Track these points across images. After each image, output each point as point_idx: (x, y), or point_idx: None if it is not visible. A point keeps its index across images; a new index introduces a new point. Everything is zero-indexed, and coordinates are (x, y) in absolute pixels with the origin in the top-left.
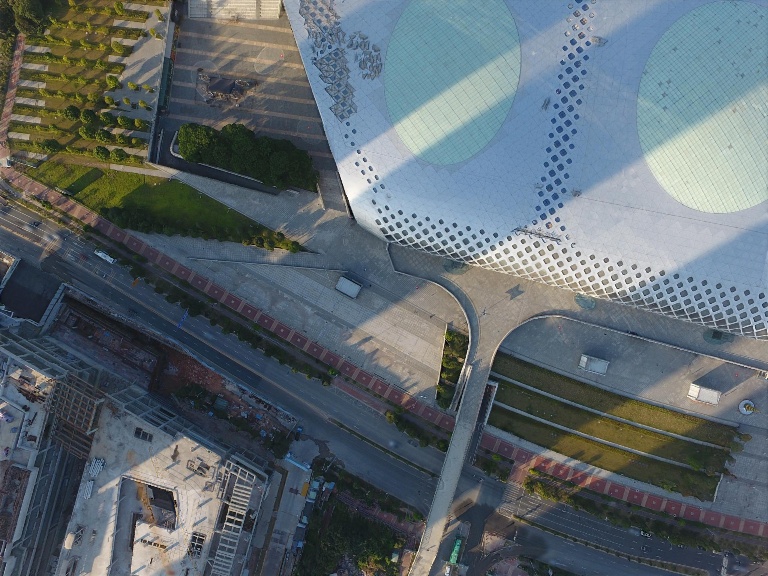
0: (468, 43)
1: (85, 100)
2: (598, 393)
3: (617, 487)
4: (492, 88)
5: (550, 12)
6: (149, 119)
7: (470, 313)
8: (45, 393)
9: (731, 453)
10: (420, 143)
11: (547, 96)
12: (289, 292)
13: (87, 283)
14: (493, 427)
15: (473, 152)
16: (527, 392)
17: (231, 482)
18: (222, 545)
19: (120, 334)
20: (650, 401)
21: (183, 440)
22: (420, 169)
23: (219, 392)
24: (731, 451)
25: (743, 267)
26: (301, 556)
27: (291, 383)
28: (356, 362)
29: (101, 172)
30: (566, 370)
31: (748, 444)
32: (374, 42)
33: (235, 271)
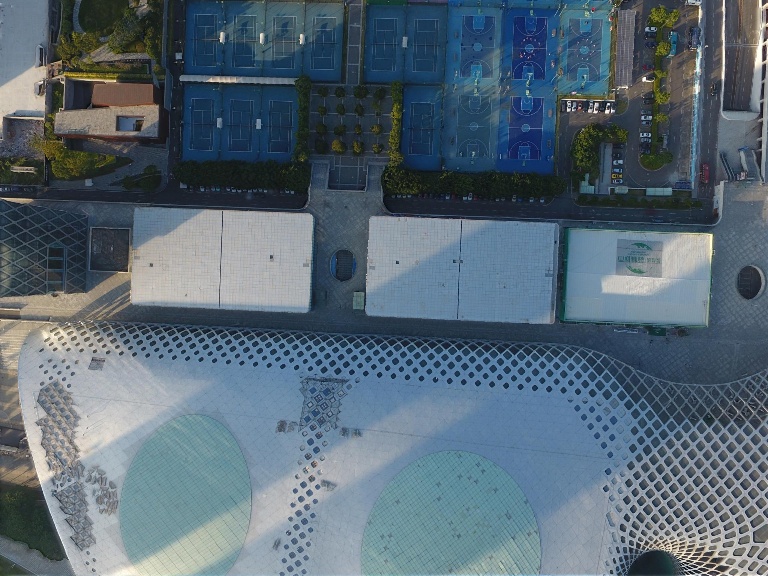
0: (199, 486)
1: None
2: None
3: None
4: (222, 530)
5: (282, 454)
6: None
7: None
8: None
9: None
10: None
11: (277, 537)
12: None
13: None
14: None
15: None
16: None
17: None
18: None
19: None
20: None
21: None
22: None
23: None
24: None
25: None
26: None
27: None
28: None
29: None
30: None
31: None
32: (111, 478)
33: None
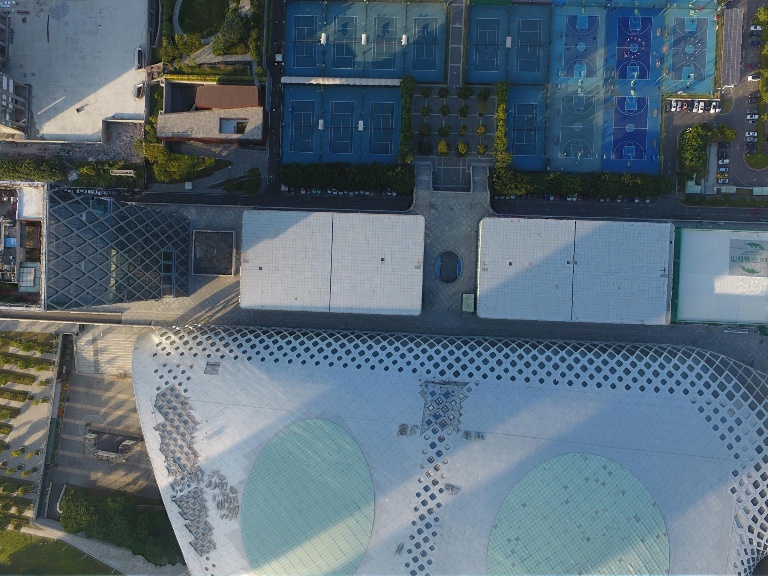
0: (322, 491)
1: None
2: None
3: None
4: (346, 535)
5: (404, 457)
6: (35, 480)
7: None
8: None
9: None
10: None
11: (401, 541)
12: None
13: None
14: None
15: None
16: None
17: None
18: None
19: None
20: None
21: None
22: None
23: None
24: None
25: None
26: None
27: None
28: None
29: None
30: None
31: None
32: (232, 483)
33: None
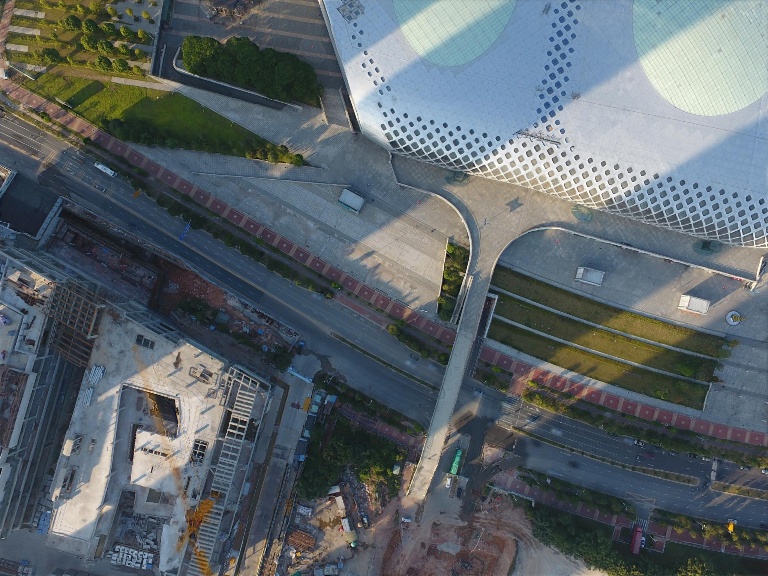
0: None
1: (86, 12)
2: (594, 305)
3: (612, 398)
4: None
5: None
6: (152, 32)
7: (471, 225)
8: (44, 296)
9: None
10: (426, 44)
11: (548, 1)
12: (292, 207)
13: (86, 197)
14: (492, 340)
15: (477, 54)
16: (526, 305)
17: (233, 392)
18: (225, 452)
19: (119, 250)
20: (643, 313)
21: (186, 347)
22: (425, 71)
23: (221, 307)
24: (719, 361)
25: (731, 169)
26: (303, 469)
27: (293, 298)
28: (358, 277)
29: (102, 85)
30: (563, 283)
31: (735, 354)
32: None
33: (238, 186)
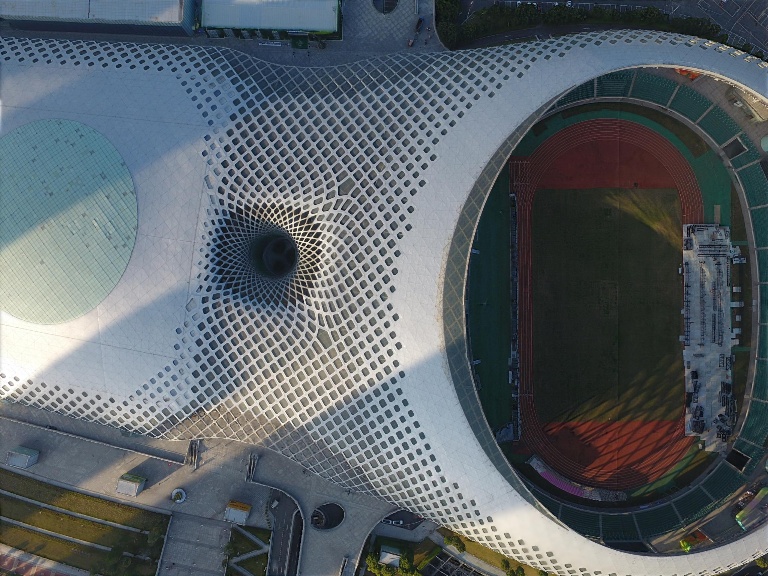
0: None
1: None
2: (35, 484)
3: (61, 575)
4: None
5: None
6: None
7: None
8: None
9: (169, 540)
10: None
11: None
12: None
13: None
14: None
15: None
16: None
17: None
18: None
19: None
20: (86, 491)
21: None
22: None
23: None
24: (168, 538)
25: (85, 374)
26: None
27: None
28: None
29: None
30: (4, 462)
31: (184, 531)
32: None
33: None
